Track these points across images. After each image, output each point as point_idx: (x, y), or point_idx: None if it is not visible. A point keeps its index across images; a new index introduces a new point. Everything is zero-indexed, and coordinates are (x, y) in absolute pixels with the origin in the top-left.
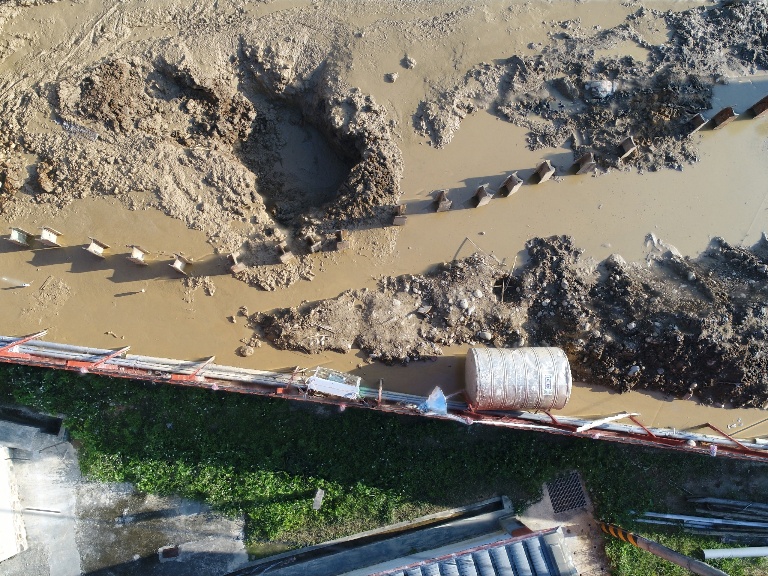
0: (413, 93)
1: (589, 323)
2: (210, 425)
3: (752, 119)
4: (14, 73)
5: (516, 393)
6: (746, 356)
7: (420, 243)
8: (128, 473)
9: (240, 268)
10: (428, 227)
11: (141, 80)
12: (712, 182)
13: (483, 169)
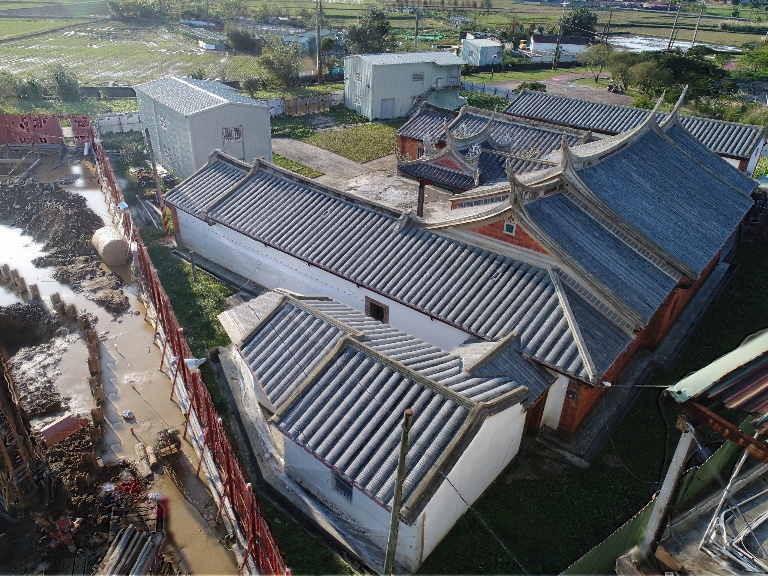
0: None
1: None
2: None
3: None
4: None
5: None
6: None
7: None
8: None
9: None
10: None
11: None
12: None
13: None
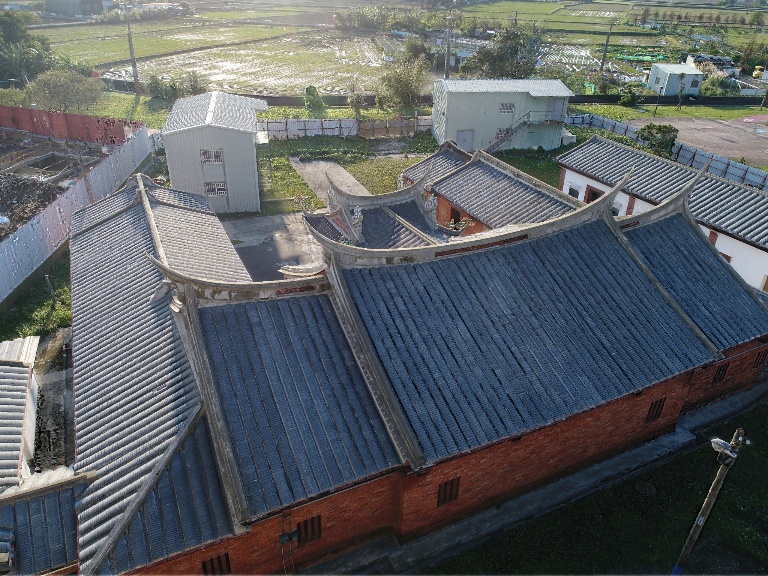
0: None
1: None
2: None
3: None
4: None
5: None
6: None
7: None
8: None
9: None
10: None
11: None
12: None
13: None
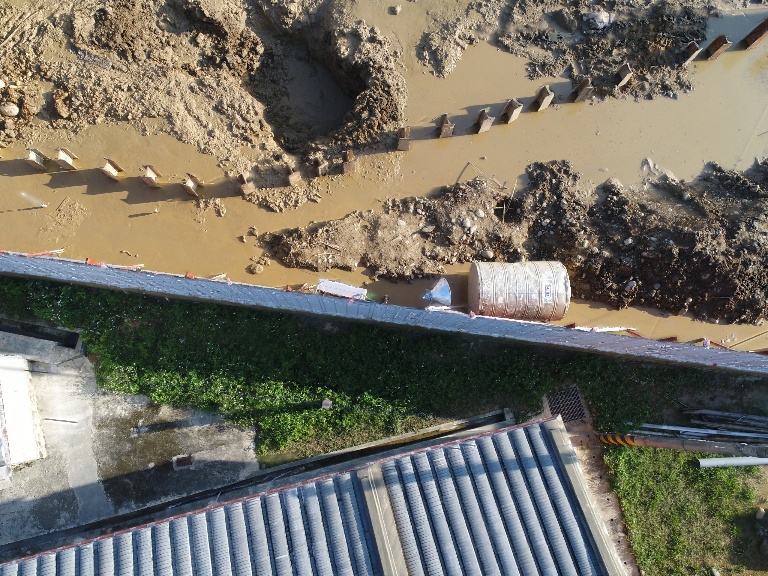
0: (416, 25)
1: (587, 240)
2: (221, 340)
3: (745, 50)
4: (30, 5)
5: (517, 301)
6: (739, 269)
7: (424, 167)
8: (143, 385)
9: (250, 189)
10: (431, 152)
11: (152, 13)
12: (706, 110)
13: (484, 97)
